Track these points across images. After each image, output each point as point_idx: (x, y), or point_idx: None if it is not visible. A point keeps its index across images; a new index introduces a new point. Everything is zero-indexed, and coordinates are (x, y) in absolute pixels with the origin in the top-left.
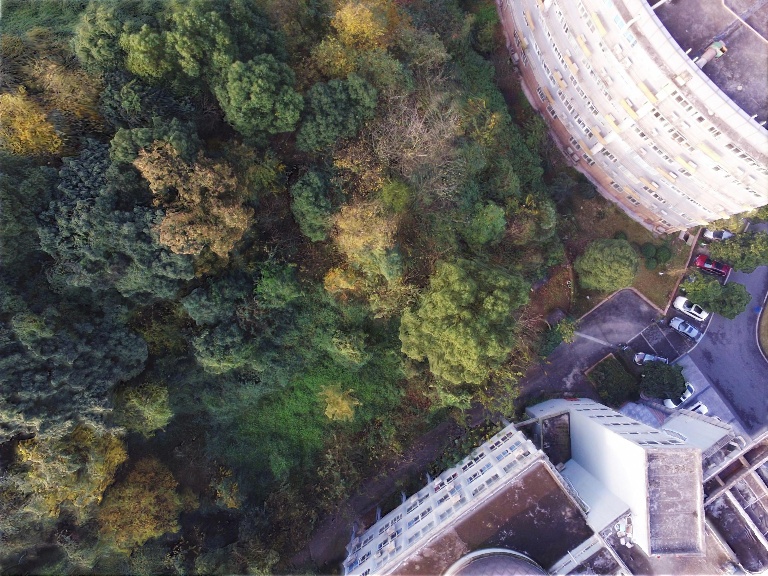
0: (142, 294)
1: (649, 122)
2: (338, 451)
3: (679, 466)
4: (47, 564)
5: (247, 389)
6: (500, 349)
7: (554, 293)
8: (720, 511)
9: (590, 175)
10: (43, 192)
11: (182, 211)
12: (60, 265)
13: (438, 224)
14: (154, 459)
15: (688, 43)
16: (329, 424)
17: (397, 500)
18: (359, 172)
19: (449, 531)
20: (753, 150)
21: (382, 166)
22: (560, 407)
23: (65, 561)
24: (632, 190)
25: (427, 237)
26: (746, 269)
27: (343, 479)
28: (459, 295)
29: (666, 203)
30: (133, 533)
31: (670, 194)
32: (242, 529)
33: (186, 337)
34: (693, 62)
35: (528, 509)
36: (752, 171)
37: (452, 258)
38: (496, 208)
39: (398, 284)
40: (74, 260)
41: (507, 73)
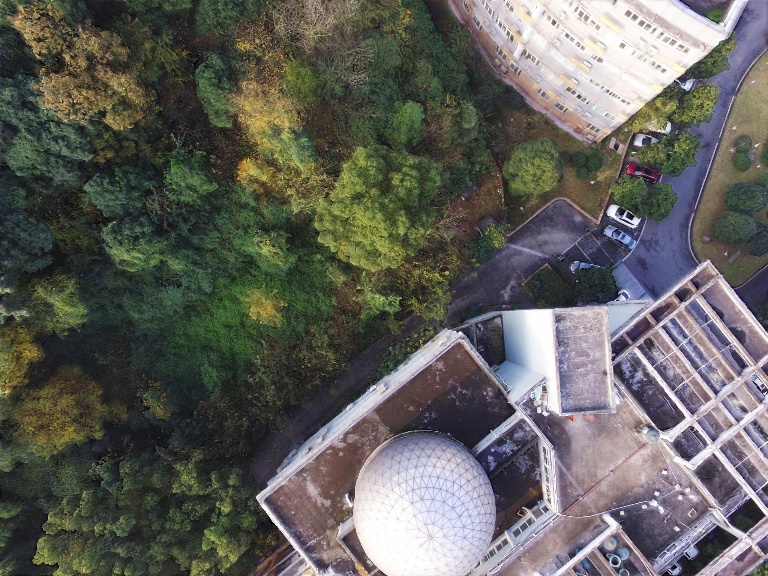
0: (42, 180)
1: (557, 5)
2: (266, 356)
3: (587, 326)
4: None
5: (168, 293)
6: (414, 230)
7: (485, 202)
8: (639, 384)
9: (519, 87)
10: None
11: (68, 76)
12: None
13: (358, 124)
14: (74, 367)
15: None
16: (261, 337)
17: None
18: (264, 55)
19: (371, 416)
20: (648, 11)
21: (284, 43)
22: (494, 313)
23: None
24: (557, 94)
25: (348, 138)
26: (674, 172)
27: (273, 385)
28: (367, 171)
29: (589, 104)
30: (51, 437)
31: (590, 90)
32: (172, 440)
33: (98, 234)
34: None
35: (449, 390)
36: (653, 40)
37: None
38: (414, 103)
39: (312, 172)
40: None
41: None
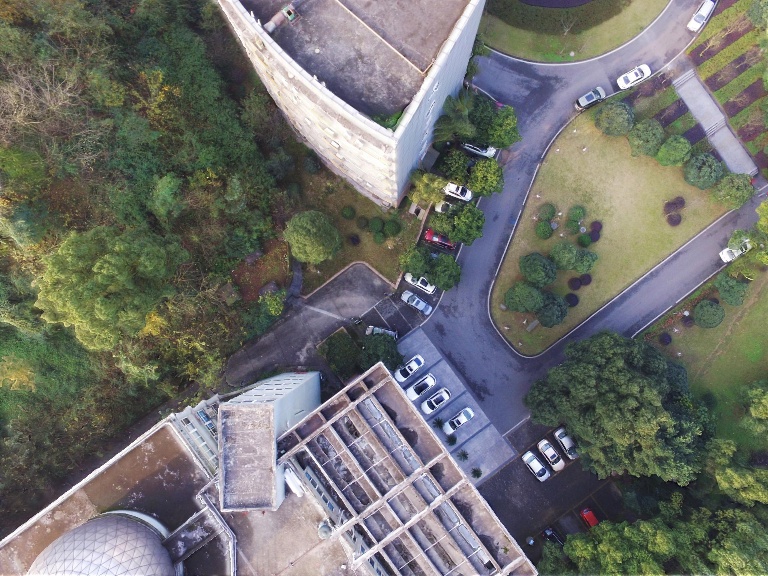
0: None
1: None
2: None
3: (255, 422)
4: None
5: None
6: (123, 313)
7: (272, 266)
8: (346, 471)
9: None
10: None
11: None
12: None
13: (116, 196)
14: None
15: (267, 7)
16: (34, 397)
17: None
18: None
19: (80, 494)
20: (331, 112)
21: None
22: None
23: None
24: (340, 163)
25: (107, 209)
26: (465, 241)
27: (28, 449)
28: (65, 259)
29: None
30: None
31: None
32: None
33: None
34: (258, 25)
35: (157, 471)
36: None
37: None
38: (165, 179)
39: (35, 251)
40: None
41: (235, 51)
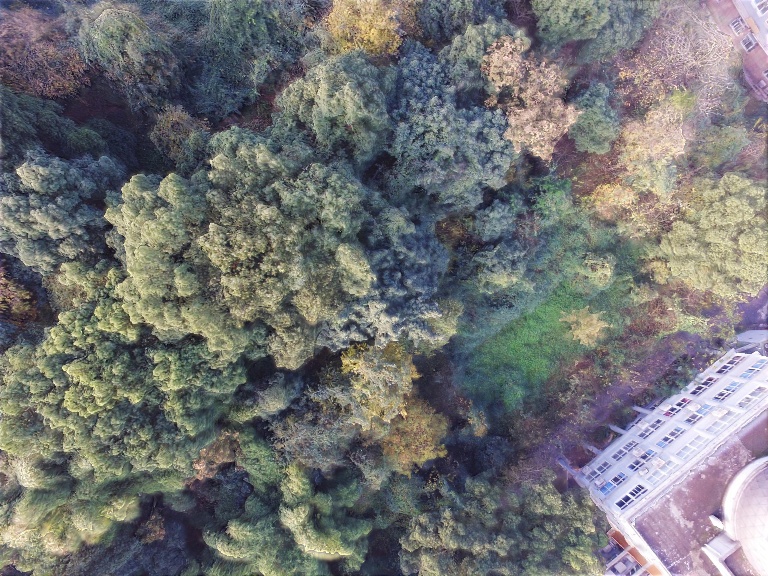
0: (444, 206)
1: None
2: (583, 376)
3: None
4: (340, 486)
5: (501, 314)
6: None
7: None
8: None
9: None
10: (391, 91)
11: (526, 108)
12: (405, 165)
13: None
14: (414, 386)
15: None
16: (554, 355)
17: None
18: (641, 84)
19: (733, 439)
20: None
21: (677, 73)
22: None
23: (356, 482)
24: None
25: None
26: None
27: (586, 404)
28: (754, 200)
29: None
30: (412, 455)
31: None
32: (488, 458)
33: (460, 257)
34: None
35: None
36: None
37: (711, 174)
38: None
39: (670, 198)
40: (422, 159)
41: None
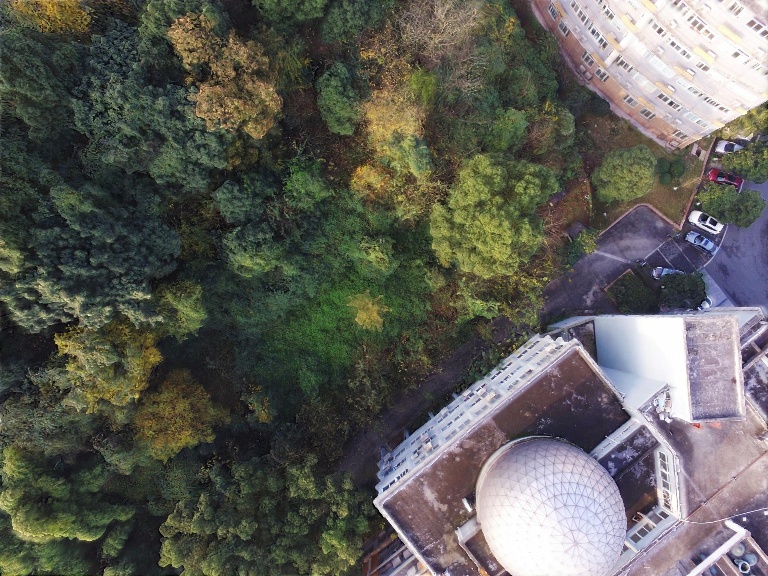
0: (173, 187)
1: (668, 14)
2: (368, 361)
3: (716, 333)
4: (83, 471)
5: (276, 298)
6: (532, 237)
7: (573, 207)
8: (752, 390)
9: (603, 93)
10: (75, 68)
11: (217, 85)
12: (94, 144)
13: (460, 130)
14: (185, 371)
15: None
16: (356, 341)
17: (424, 422)
18: (386, 64)
19: (487, 422)
20: None
21: (410, 52)
22: (584, 318)
23: (101, 467)
24: (646, 101)
25: (450, 144)
26: (759, 179)
27: (374, 390)
28: (491, 179)
29: (681, 111)
30: (168, 440)
31: (686, 97)
32: (274, 444)
33: (215, 240)
34: None
35: (565, 396)
36: None
37: None
38: (518, 111)
39: (427, 179)
40: (109, 137)
41: None
